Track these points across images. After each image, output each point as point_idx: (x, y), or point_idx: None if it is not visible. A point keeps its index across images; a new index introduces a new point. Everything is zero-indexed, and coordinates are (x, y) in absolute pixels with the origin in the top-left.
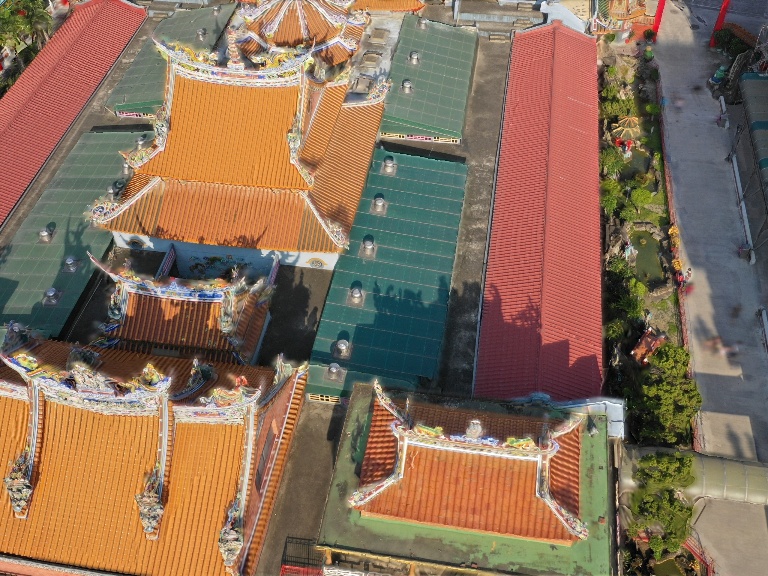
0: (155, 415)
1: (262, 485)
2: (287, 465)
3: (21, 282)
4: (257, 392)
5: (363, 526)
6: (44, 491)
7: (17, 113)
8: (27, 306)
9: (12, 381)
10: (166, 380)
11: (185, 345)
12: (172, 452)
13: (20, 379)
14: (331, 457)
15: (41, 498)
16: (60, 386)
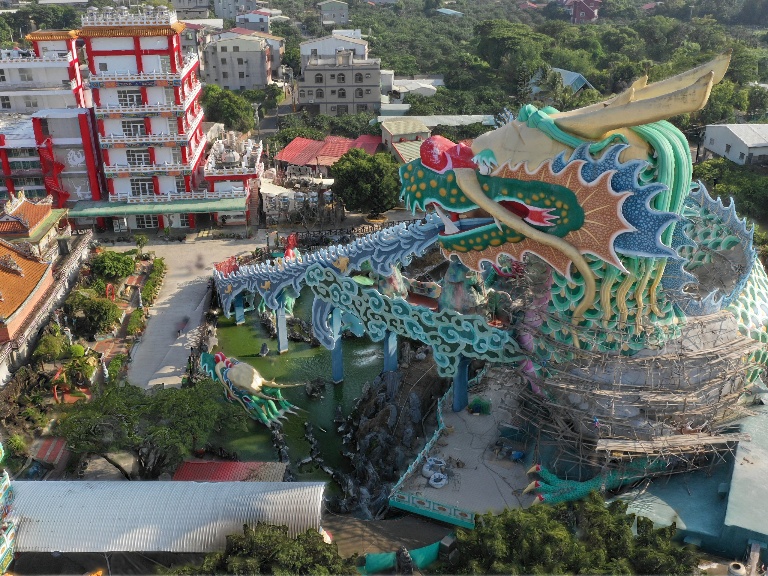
0: None
1: None
2: None
3: None
4: None
5: None
6: None
7: None
8: None
9: None
10: None
11: None
12: None
13: None
14: None
15: None
16: None
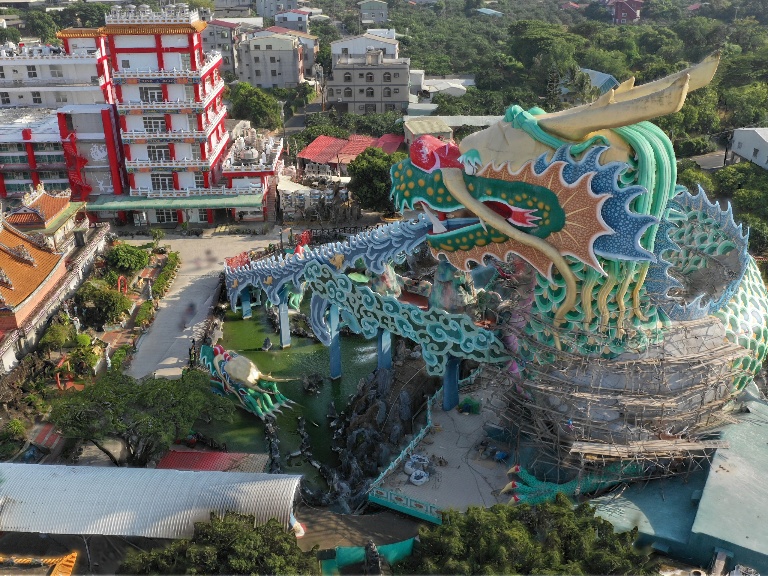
0: None
1: None
2: None
3: None
4: None
5: (50, 228)
6: None
7: None
8: None
9: None
10: None
11: None
12: None
13: None
14: None
15: None
16: None
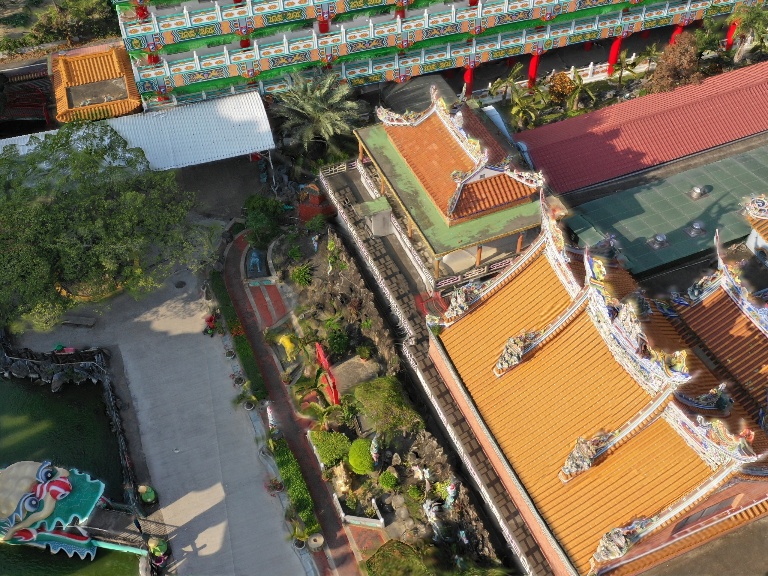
0: (651, 394)
1: (680, 532)
2: (716, 540)
3: (646, 213)
4: (753, 456)
5: None
6: (526, 371)
7: (764, 81)
8: (634, 234)
9: (576, 276)
10: (686, 375)
11: (726, 366)
12: (636, 434)
13: (582, 280)
14: (762, 575)
15: (519, 373)
16: (604, 308)
